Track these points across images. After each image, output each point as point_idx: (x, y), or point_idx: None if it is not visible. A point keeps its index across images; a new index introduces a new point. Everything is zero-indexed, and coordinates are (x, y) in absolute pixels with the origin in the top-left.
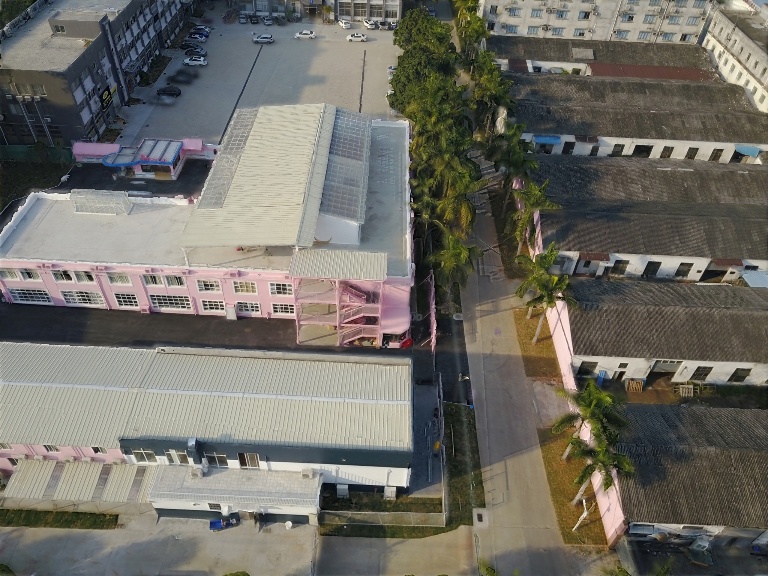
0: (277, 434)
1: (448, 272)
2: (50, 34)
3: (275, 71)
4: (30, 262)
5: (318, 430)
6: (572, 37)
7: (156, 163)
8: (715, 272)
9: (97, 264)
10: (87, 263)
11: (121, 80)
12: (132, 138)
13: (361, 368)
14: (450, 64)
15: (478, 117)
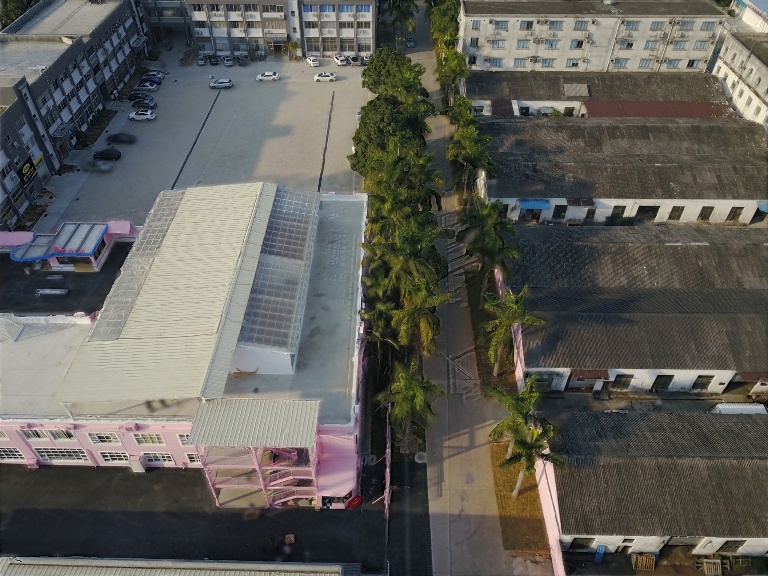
0: None
1: (400, 417)
2: None
3: (231, 122)
4: None
5: None
6: (564, 68)
7: (73, 255)
8: (742, 382)
9: None
10: None
11: (49, 147)
12: (58, 216)
13: None
14: (418, 118)
15: (456, 172)
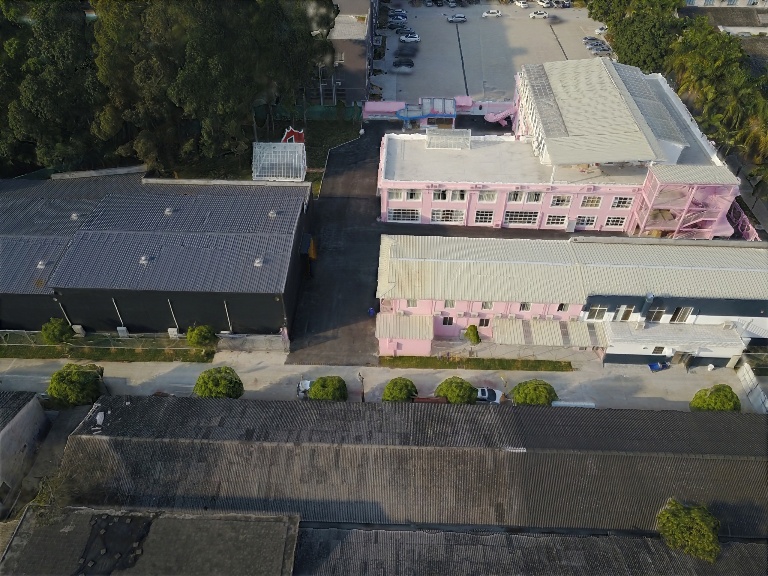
0: (705, 293)
1: None
2: None
3: (481, 45)
4: (420, 183)
5: (736, 290)
6: (746, 6)
7: (442, 116)
8: None
9: (476, 183)
10: (467, 182)
11: None
12: None
13: (741, 250)
14: (677, 26)
15: None
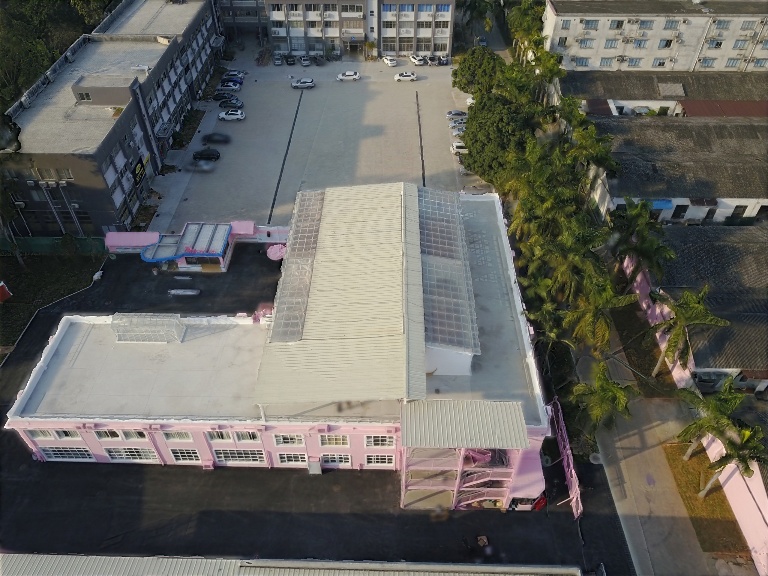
0: None
1: (595, 418)
2: (73, 102)
3: (321, 122)
4: (67, 422)
5: None
6: (650, 68)
7: (203, 255)
8: None
9: (150, 422)
10: (138, 421)
11: (154, 147)
12: (170, 217)
13: None
14: (535, 118)
15: None
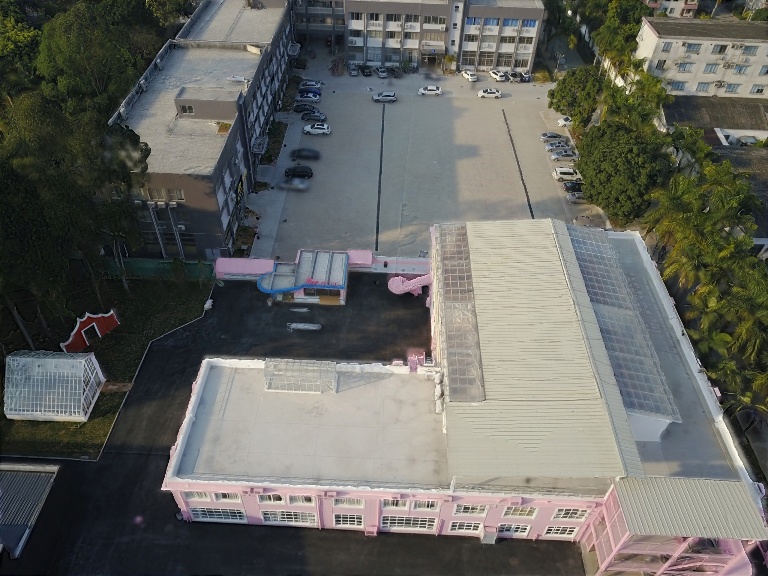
0: None
1: None
2: (173, 114)
3: (410, 140)
4: (232, 485)
5: None
6: (748, 94)
7: (324, 287)
8: None
9: (325, 488)
10: (311, 487)
11: None
12: (272, 239)
13: None
14: (663, 149)
15: None
